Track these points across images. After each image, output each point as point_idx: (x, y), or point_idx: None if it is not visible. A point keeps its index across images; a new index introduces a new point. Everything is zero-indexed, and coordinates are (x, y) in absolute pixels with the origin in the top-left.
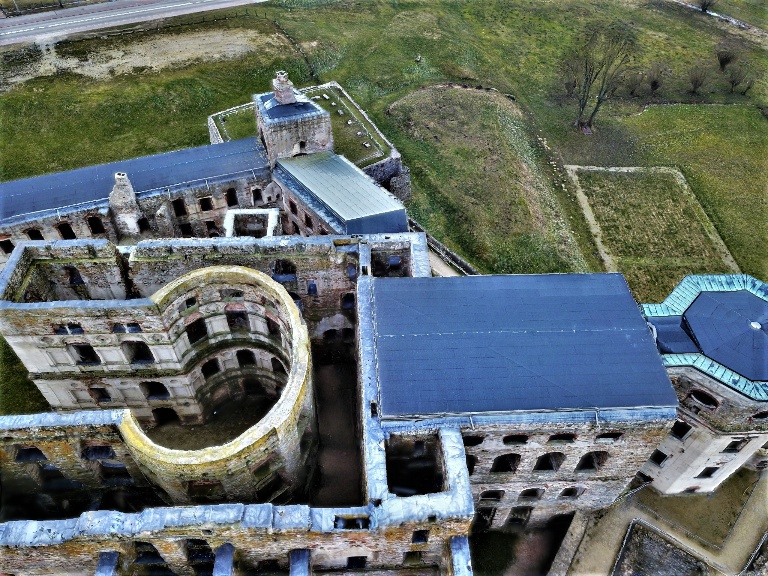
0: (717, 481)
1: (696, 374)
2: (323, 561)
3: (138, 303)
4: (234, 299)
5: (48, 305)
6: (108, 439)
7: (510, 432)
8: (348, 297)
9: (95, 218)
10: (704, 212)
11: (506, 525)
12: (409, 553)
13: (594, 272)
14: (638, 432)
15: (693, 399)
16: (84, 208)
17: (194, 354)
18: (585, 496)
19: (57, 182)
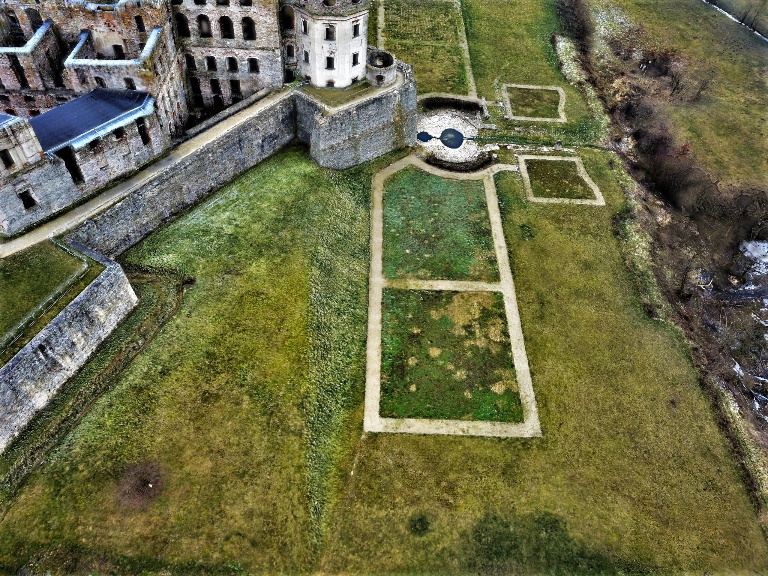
0: (341, 75)
1: None
2: (102, 49)
3: None
4: None
5: None
6: None
7: None
8: None
9: None
10: (463, 22)
11: None
12: None
13: None
14: None
15: None
16: None
17: None
18: (262, 70)
19: None
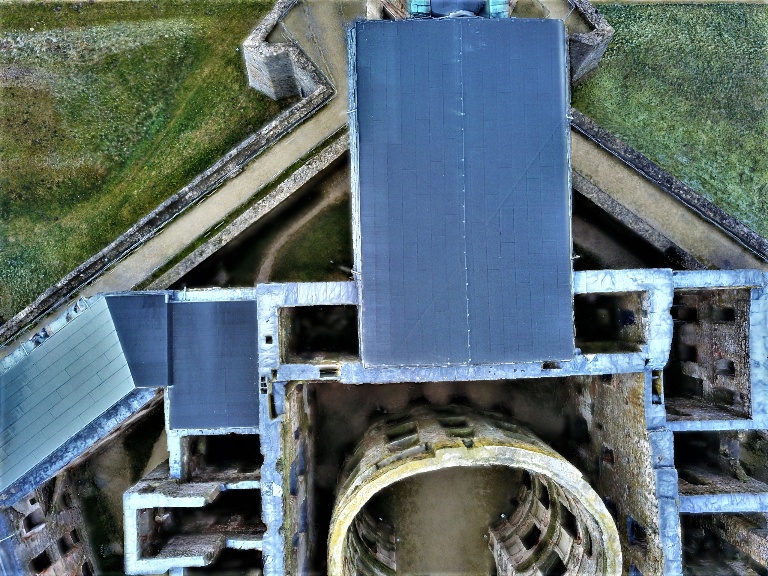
0: None
1: None
2: None
3: None
4: None
5: None
6: None
7: None
8: None
9: None
10: None
11: None
12: None
13: (115, 21)
14: None
15: None
16: None
17: (375, 569)
18: None
19: None
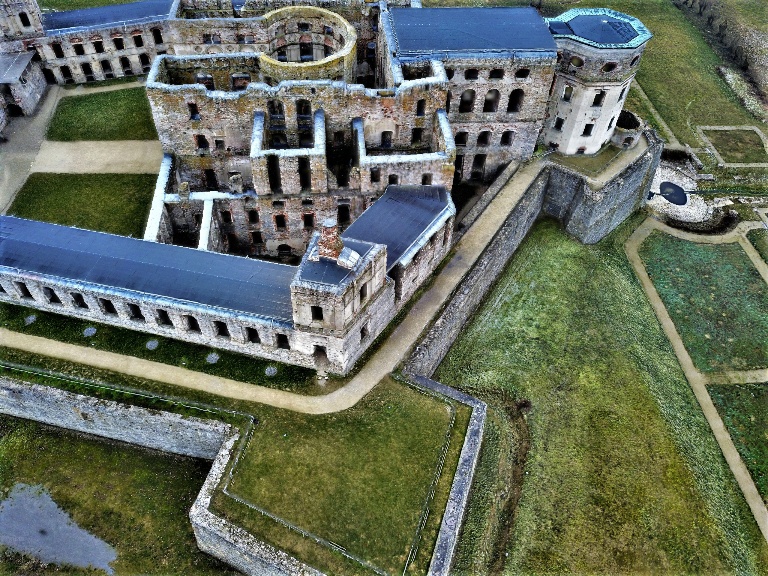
0: (595, 141)
1: (571, 45)
2: (369, 136)
3: (255, 18)
4: (306, 32)
5: (204, 19)
6: (251, 70)
7: (468, 66)
8: (371, 51)
9: None
10: None
11: (472, 182)
12: (415, 139)
13: None
14: (538, 70)
15: (572, 65)
16: None
17: None
18: (516, 142)
19: (168, 2)
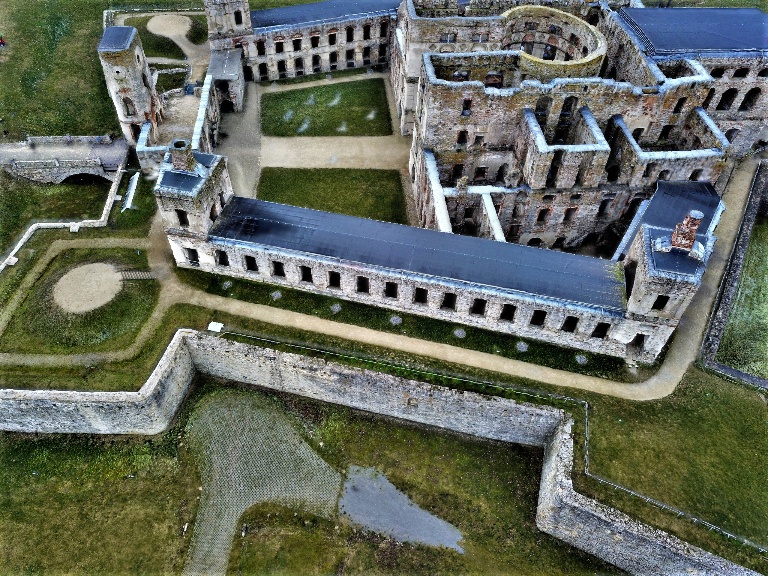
0: None
1: None
2: None
3: (495, 18)
4: (530, 31)
5: (446, 18)
6: (509, 68)
7: (717, 65)
8: None
9: (385, 23)
10: None
11: None
12: (660, 136)
13: None
14: None
15: None
16: (382, 14)
17: (499, 71)
18: (737, 140)
19: (357, 1)
